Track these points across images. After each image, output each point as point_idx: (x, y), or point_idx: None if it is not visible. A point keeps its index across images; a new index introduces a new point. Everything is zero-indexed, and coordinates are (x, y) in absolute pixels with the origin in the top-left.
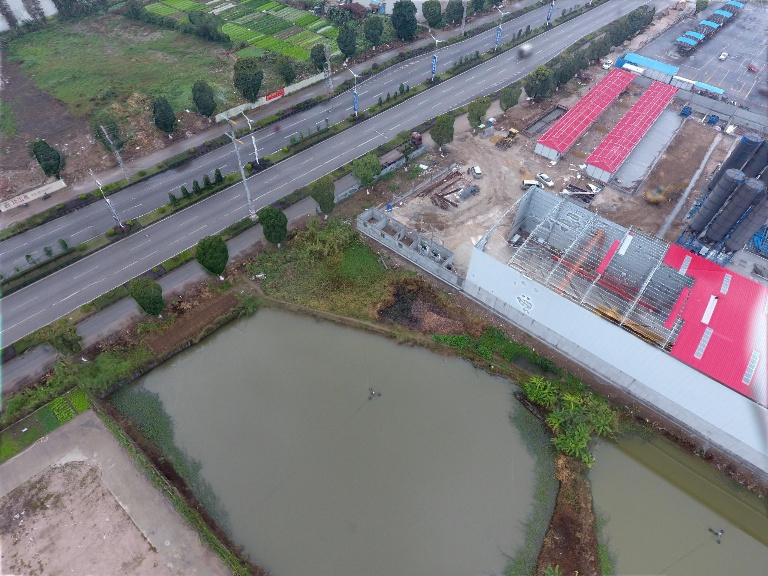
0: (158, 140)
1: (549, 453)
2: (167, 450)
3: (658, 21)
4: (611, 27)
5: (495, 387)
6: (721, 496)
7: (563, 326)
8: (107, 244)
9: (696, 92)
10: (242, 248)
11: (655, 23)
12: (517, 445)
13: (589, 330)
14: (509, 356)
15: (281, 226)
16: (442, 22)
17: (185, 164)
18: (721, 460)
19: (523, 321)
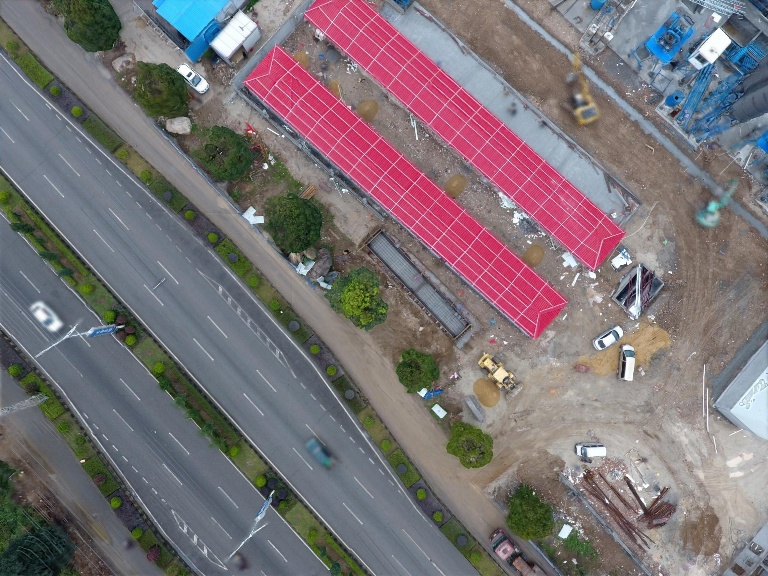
0: None
1: None
2: None
3: None
4: (79, 33)
5: None
6: None
7: None
8: None
9: None
10: None
11: None
12: None
13: None
14: None
15: None
16: None
17: None
18: None
19: None
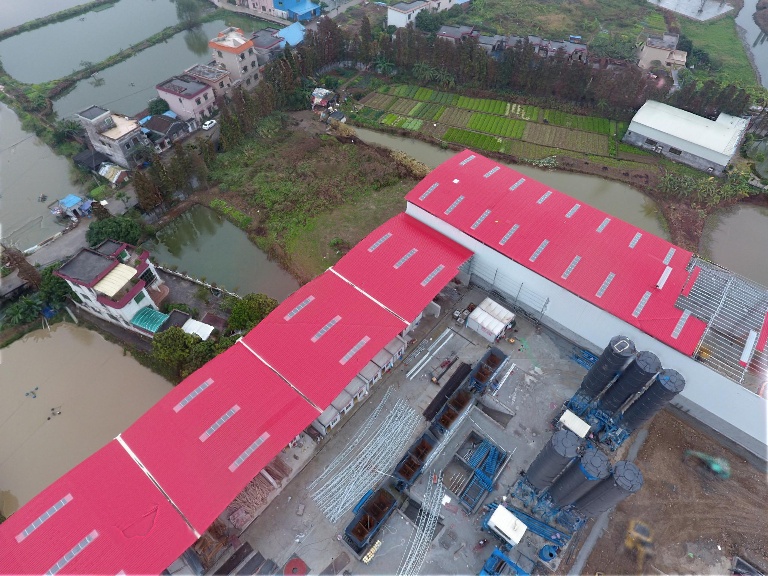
0: None
1: None
2: None
3: None
4: None
5: None
6: None
7: None
8: None
9: None
10: None
11: None
12: None
13: None
14: None
15: None
16: None
17: None
18: None
19: None
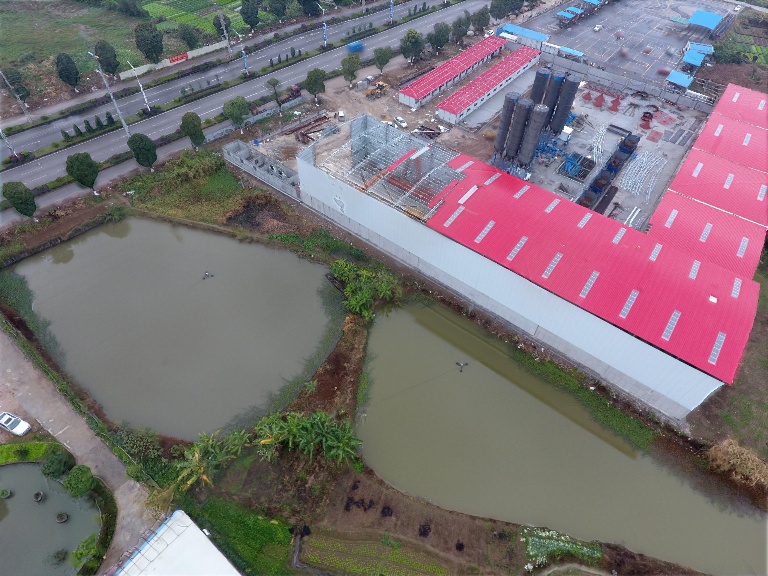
0: (65, 93)
1: (342, 314)
2: (24, 313)
3: (550, 0)
4: (493, 1)
5: (312, 271)
6: (475, 342)
7: (366, 218)
8: (2, 170)
9: (562, 56)
10: (121, 173)
11: (546, 2)
12: (317, 309)
13: (380, 217)
14: (330, 249)
15: (147, 149)
16: (349, 0)
17: (86, 112)
18: (481, 317)
19: (344, 221)
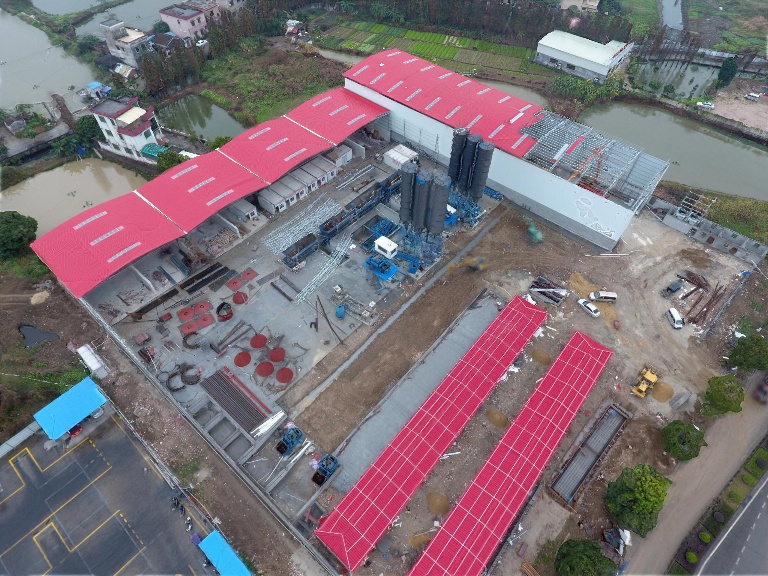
0: None
1: None
2: (765, 148)
3: None
4: None
5: None
6: None
7: None
8: None
9: None
10: None
11: None
12: None
13: None
14: None
15: None
16: None
17: None
18: None
19: None
